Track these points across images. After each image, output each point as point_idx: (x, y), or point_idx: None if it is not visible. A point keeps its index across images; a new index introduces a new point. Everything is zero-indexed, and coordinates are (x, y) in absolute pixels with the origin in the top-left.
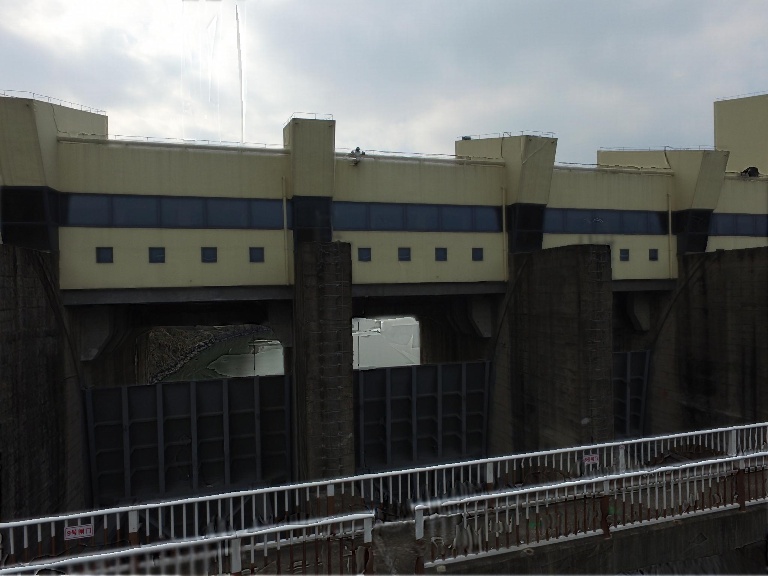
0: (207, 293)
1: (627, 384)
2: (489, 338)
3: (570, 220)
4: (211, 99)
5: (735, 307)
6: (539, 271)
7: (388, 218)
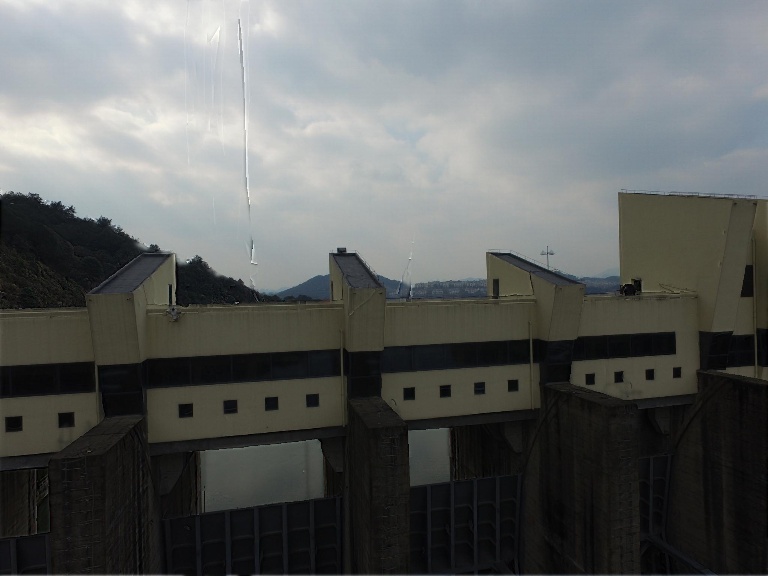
0: (13, 462)
1: (496, 510)
2: (341, 472)
3: (420, 355)
4: (215, 110)
5: (579, 456)
6: (357, 434)
7: (215, 369)
